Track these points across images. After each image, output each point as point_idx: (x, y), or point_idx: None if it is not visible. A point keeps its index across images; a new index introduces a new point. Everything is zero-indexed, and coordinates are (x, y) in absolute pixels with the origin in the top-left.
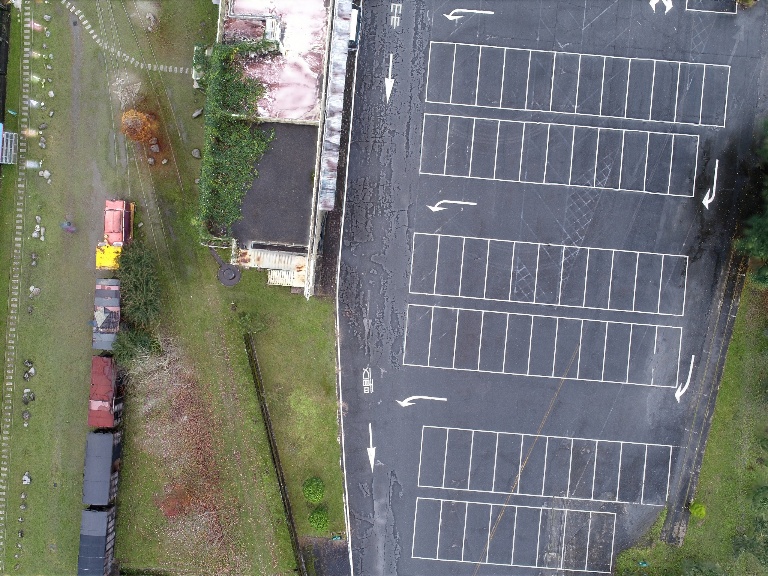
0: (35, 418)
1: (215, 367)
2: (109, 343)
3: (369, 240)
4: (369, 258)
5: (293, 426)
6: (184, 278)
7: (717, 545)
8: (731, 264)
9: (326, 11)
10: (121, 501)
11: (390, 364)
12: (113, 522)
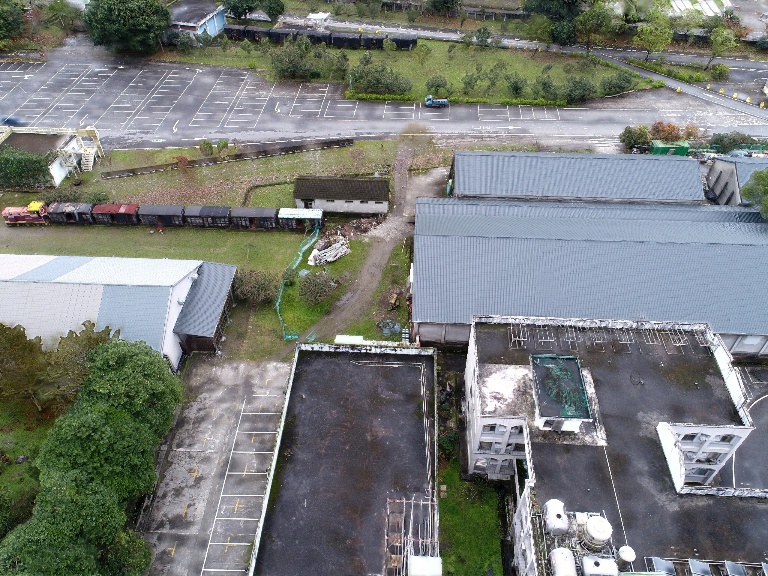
0: None
1: None
2: (87, 205)
3: None
4: None
5: None
6: None
7: None
8: (151, 62)
9: None
10: None
11: None
12: None
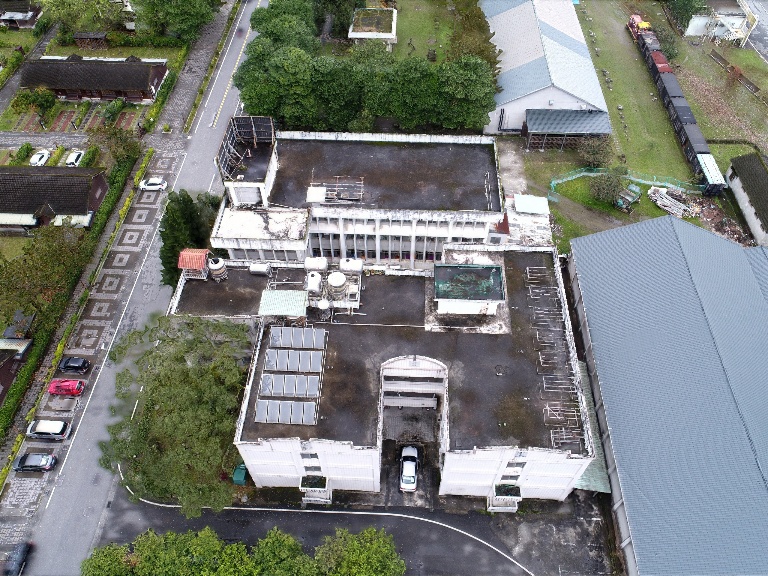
0: (615, 88)
1: None
2: (658, 47)
3: (759, 33)
4: (763, 38)
5: (761, 86)
6: None
7: None
8: None
9: None
10: None
11: None
12: None
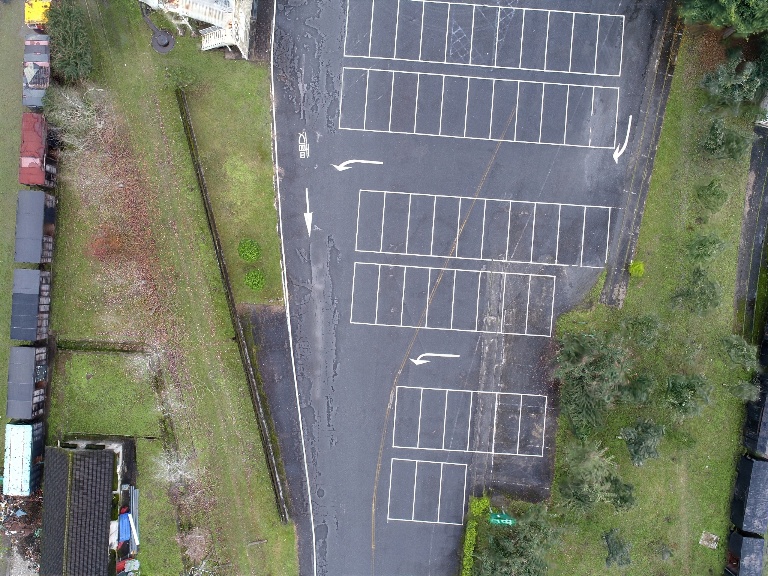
0: None
1: (150, 135)
2: (39, 99)
3: (303, 4)
4: (303, 22)
5: (229, 192)
6: (118, 46)
7: (657, 306)
8: (667, 23)
9: None
10: (57, 272)
11: (326, 128)
12: (48, 288)
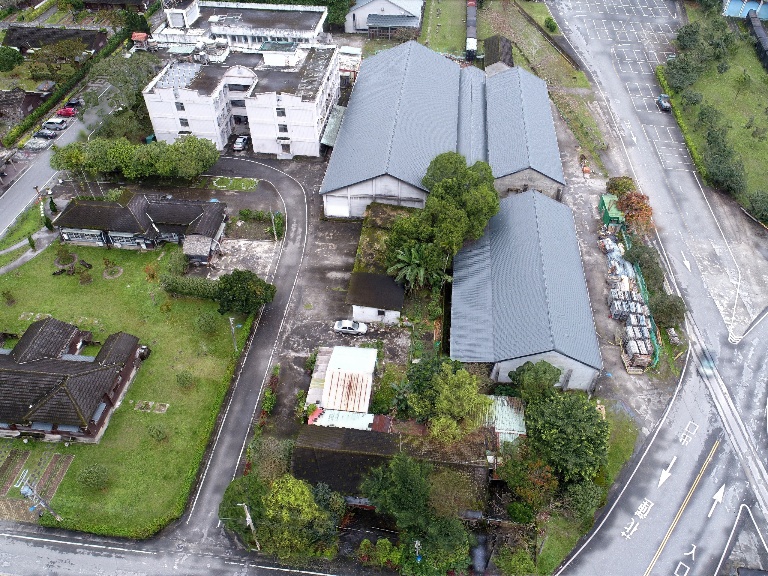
0: None
1: None
2: None
3: None
4: None
5: None
6: (491, 0)
7: None
8: None
9: None
10: None
11: None
12: None
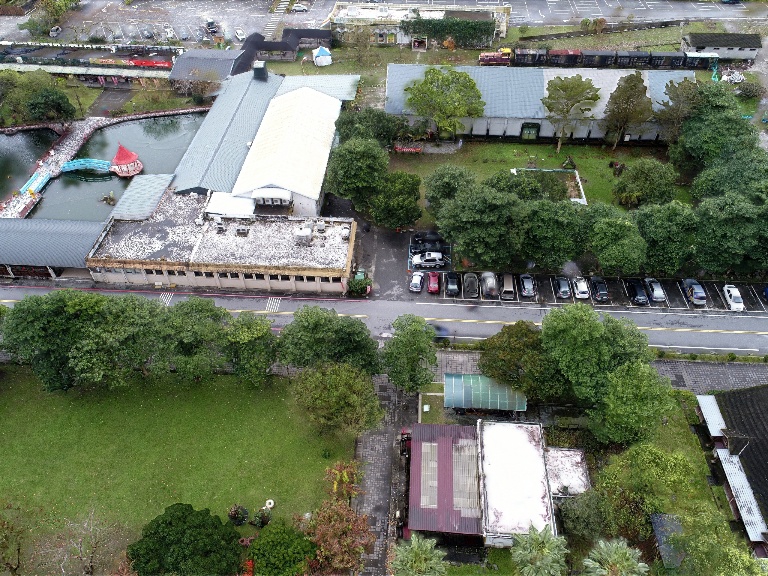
0: None
1: None
2: None
3: None
4: None
5: None
6: None
7: None
8: None
9: (402, 10)
10: None
11: None
12: None
